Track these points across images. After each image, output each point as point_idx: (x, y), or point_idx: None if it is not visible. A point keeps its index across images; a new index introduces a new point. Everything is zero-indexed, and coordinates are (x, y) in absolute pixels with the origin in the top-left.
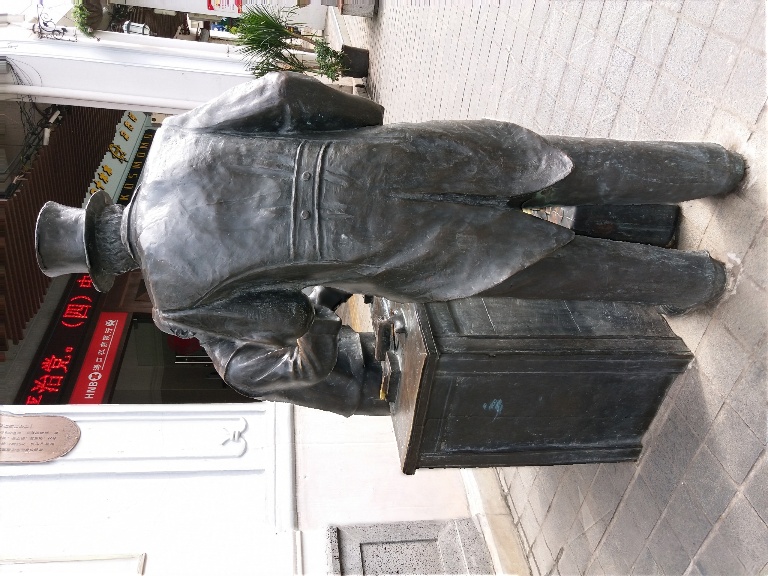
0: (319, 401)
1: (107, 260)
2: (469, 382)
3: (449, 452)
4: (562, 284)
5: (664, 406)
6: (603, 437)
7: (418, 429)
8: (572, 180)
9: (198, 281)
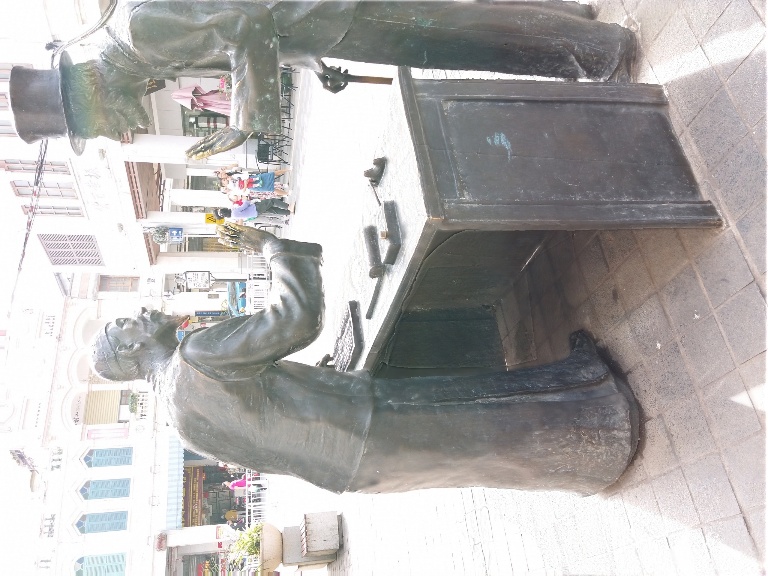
0: (315, 404)
1: (77, 75)
2: (457, 111)
3: None
4: None
5: (686, 147)
6: (655, 193)
7: (422, 150)
8: None
9: None
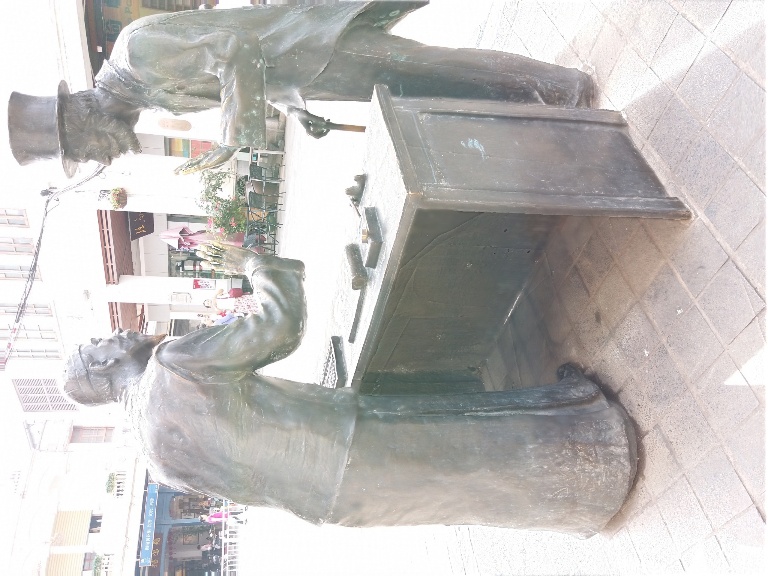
0: (296, 410)
1: None
2: (432, 121)
3: None
4: (457, 49)
5: (648, 157)
6: (624, 190)
7: (400, 144)
8: None
9: None
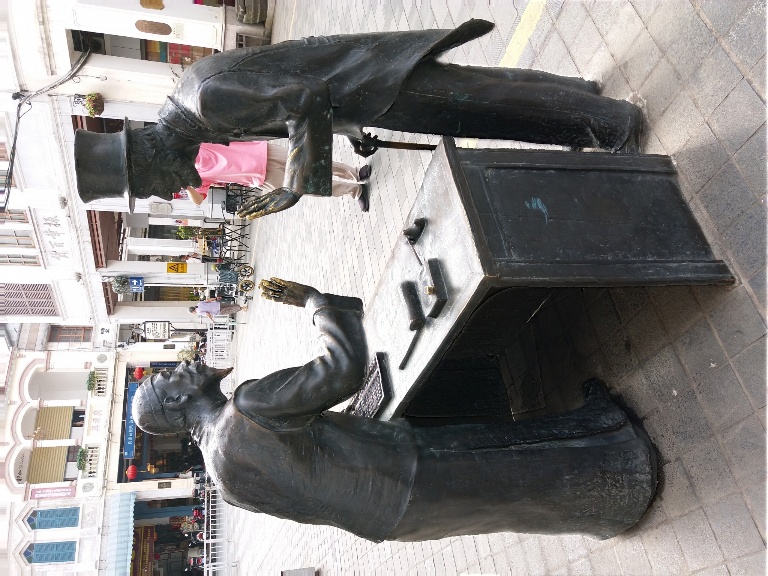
0: (363, 453)
1: (139, 139)
2: (497, 178)
3: (524, 259)
4: (516, 85)
5: (696, 211)
6: (674, 253)
7: (472, 213)
8: (486, 71)
9: (234, 56)
